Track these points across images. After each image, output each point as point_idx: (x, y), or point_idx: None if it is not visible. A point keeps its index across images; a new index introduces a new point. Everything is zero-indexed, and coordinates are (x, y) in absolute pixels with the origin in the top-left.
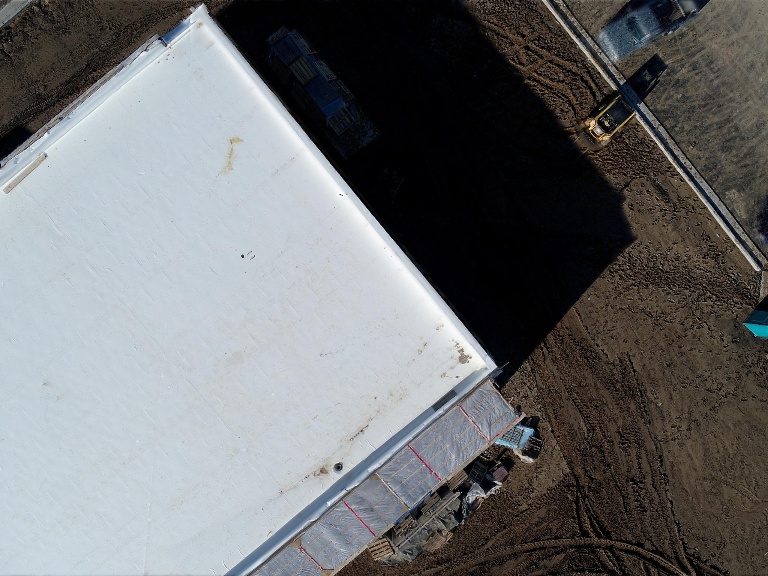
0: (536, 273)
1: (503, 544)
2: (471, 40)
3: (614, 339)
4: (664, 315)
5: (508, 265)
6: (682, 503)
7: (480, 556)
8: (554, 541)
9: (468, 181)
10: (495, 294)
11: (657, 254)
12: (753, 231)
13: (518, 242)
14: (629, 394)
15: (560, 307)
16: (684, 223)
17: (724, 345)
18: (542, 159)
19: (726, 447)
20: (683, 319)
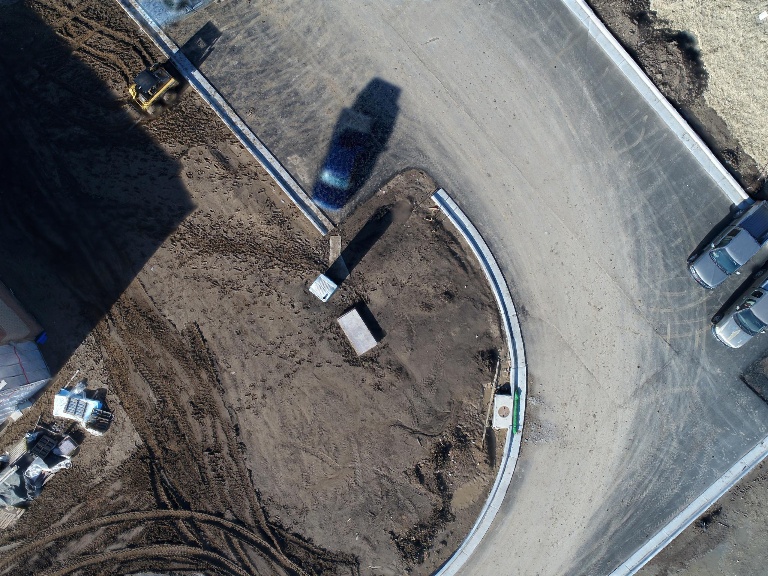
0: (96, 245)
1: (79, 518)
2: (16, 13)
3: (181, 309)
4: (231, 283)
5: (66, 238)
6: (261, 471)
7: (56, 531)
8: (132, 514)
9: (20, 155)
10: (55, 267)
11: (220, 222)
12: (317, 196)
13: (75, 214)
14: (200, 363)
15: (123, 278)
16: (246, 190)
17: (295, 311)
18: (94, 130)
19: (303, 414)
20: (251, 286)
